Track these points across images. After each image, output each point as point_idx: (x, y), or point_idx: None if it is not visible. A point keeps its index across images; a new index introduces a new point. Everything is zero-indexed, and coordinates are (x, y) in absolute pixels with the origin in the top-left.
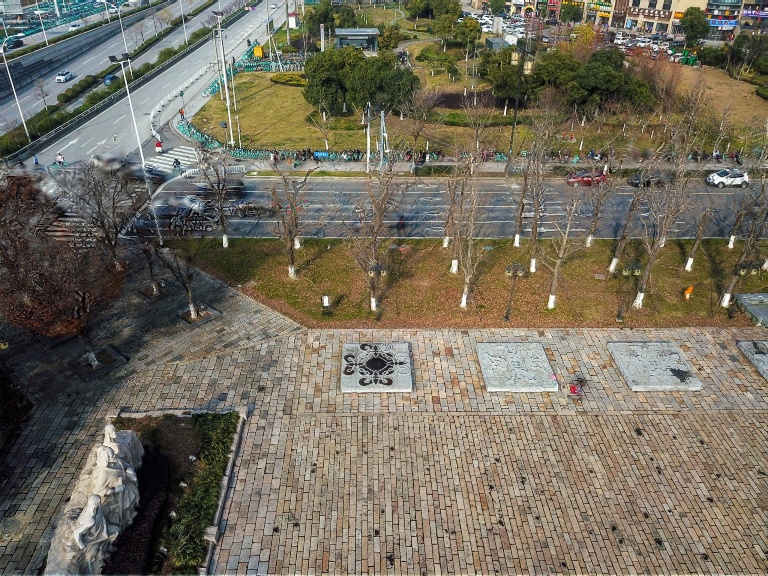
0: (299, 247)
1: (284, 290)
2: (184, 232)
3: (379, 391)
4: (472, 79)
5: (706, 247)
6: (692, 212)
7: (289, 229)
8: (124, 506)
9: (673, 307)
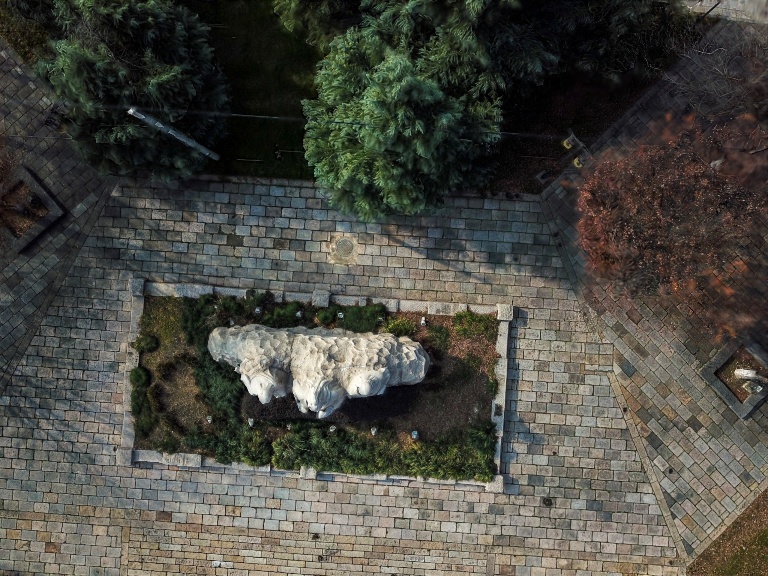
0: None
1: None
2: None
3: None
4: None
5: None
6: None
7: None
8: None
9: None
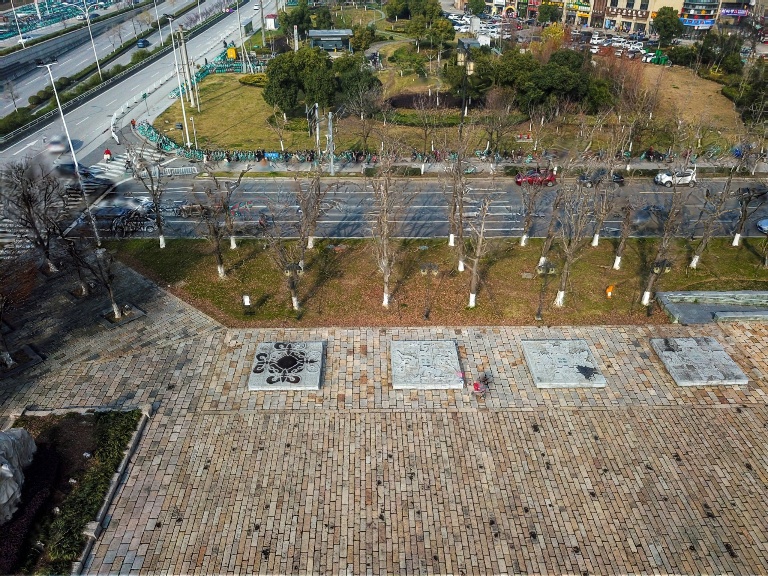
0: (235, 247)
1: (212, 290)
2: (125, 233)
3: (286, 389)
4: (419, 80)
5: (640, 246)
6: (635, 211)
7: (214, 229)
8: (1, 502)
9: (594, 305)
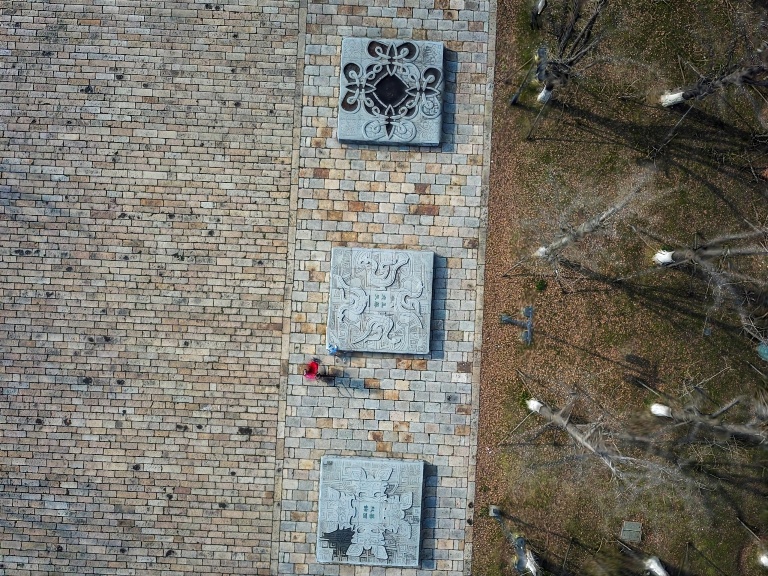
0: None
1: None
2: None
3: None
4: None
5: None
6: None
7: None
8: None
9: None
